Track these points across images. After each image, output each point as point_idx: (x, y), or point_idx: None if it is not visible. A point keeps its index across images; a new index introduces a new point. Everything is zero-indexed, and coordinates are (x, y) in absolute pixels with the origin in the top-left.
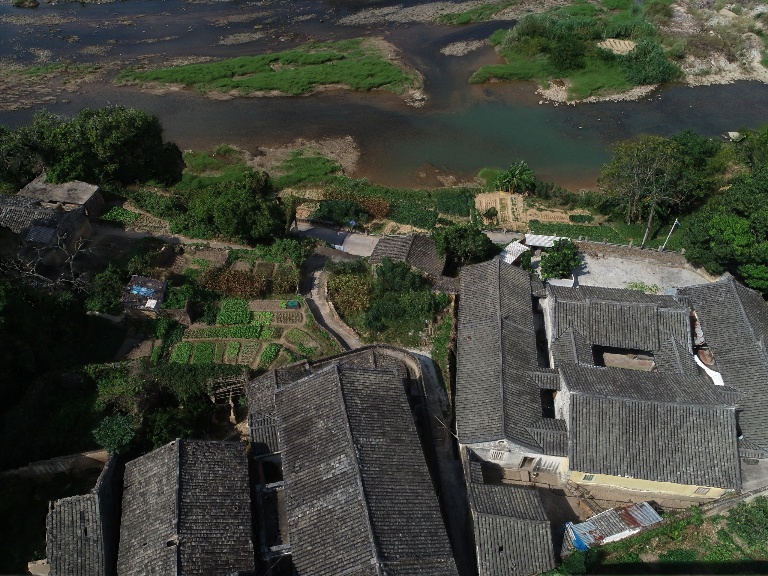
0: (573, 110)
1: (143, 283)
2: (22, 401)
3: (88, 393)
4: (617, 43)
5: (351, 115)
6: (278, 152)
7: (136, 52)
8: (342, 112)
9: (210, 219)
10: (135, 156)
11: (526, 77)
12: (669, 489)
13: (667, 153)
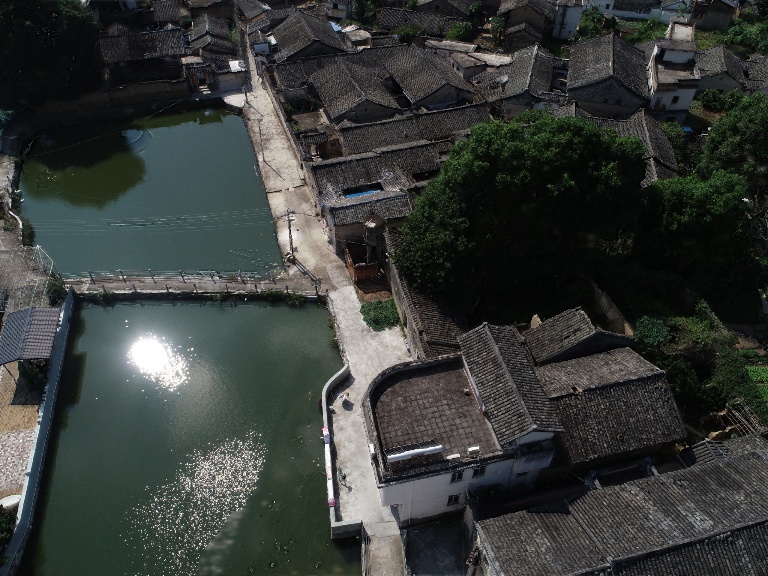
0: None
1: None
2: (651, 271)
3: (681, 316)
4: None
5: None
6: None
7: None
8: None
9: None
10: None
11: None
12: None
13: None
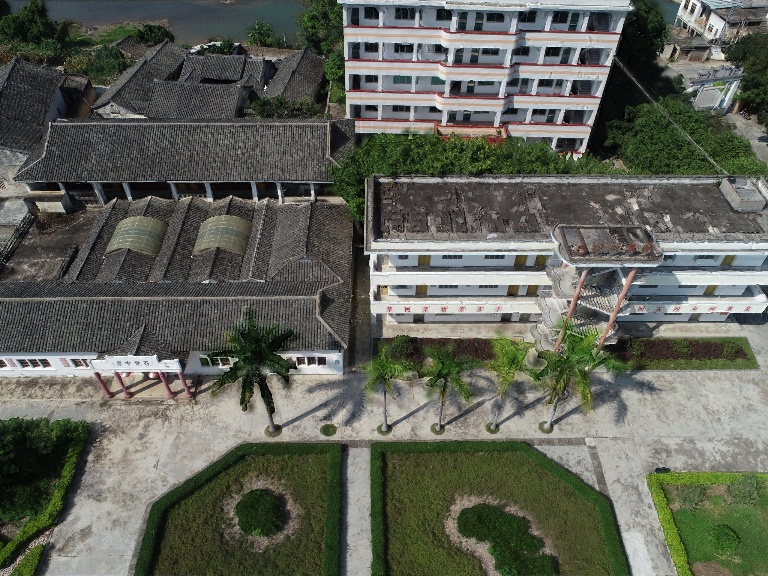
0: None
1: None
2: None
3: None
4: None
5: (174, 8)
6: (107, 28)
7: None
8: (168, 6)
9: None
10: None
11: None
12: None
13: None
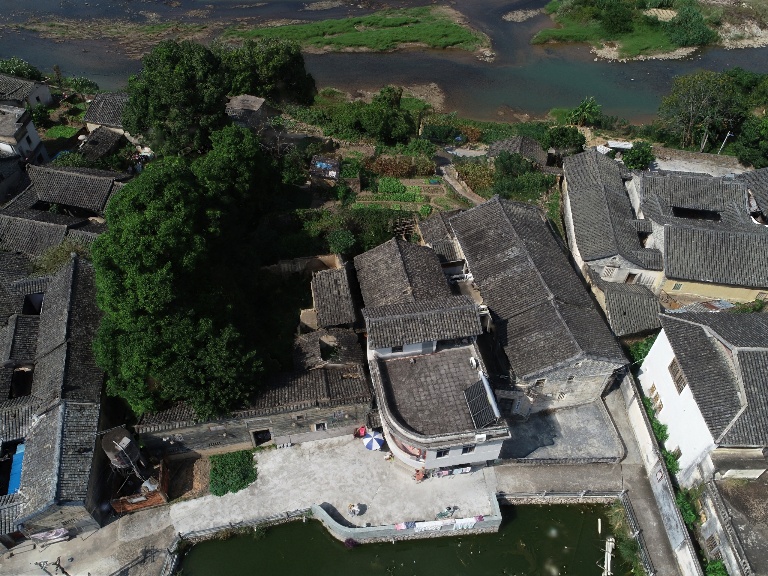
0: (625, 66)
1: (323, 160)
2: (259, 228)
3: (295, 232)
4: (660, 12)
5: (432, 67)
6: None
7: (234, 15)
8: (424, 65)
9: (356, 124)
10: (284, 80)
11: (581, 39)
12: (737, 296)
13: (719, 84)
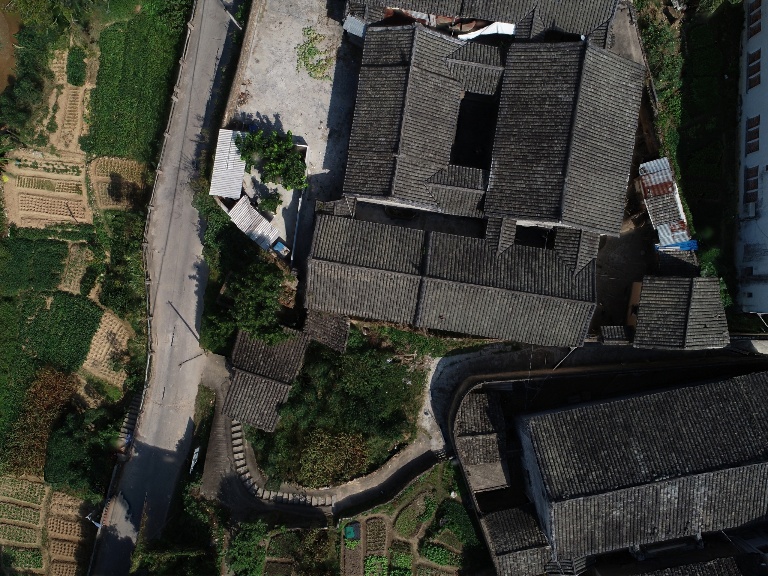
0: None
1: None
2: None
3: None
4: None
5: None
6: None
7: None
8: None
9: None
10: None
11: None
12: None
13: None
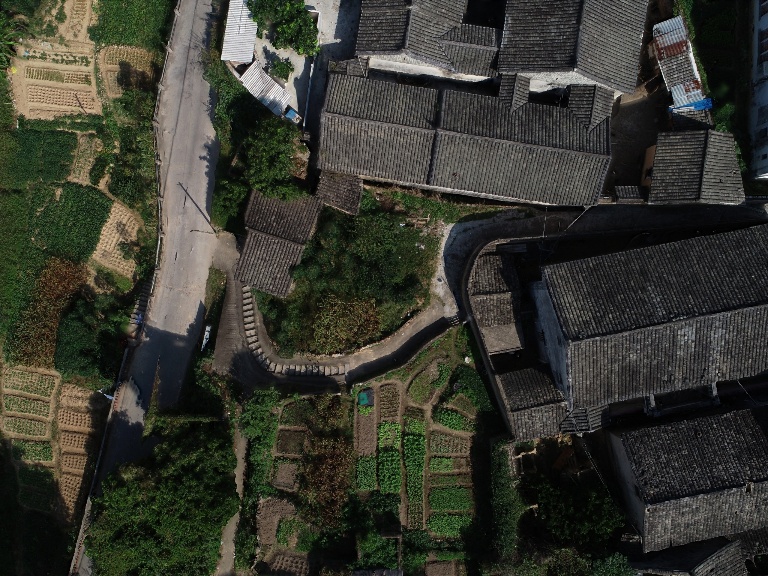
0: None
1: None
2: None
3: None
4: None
5: None
6: None
7: None
8: None
9: None
10: None
11: None
12: None
13: None
